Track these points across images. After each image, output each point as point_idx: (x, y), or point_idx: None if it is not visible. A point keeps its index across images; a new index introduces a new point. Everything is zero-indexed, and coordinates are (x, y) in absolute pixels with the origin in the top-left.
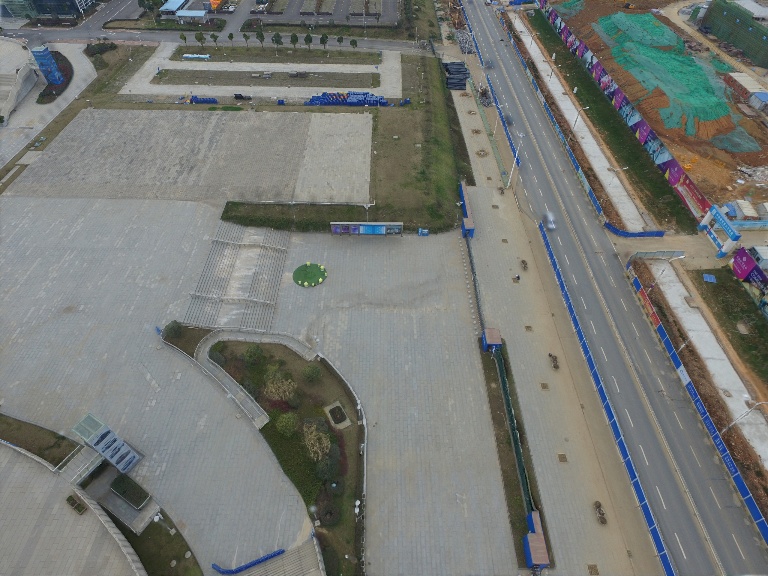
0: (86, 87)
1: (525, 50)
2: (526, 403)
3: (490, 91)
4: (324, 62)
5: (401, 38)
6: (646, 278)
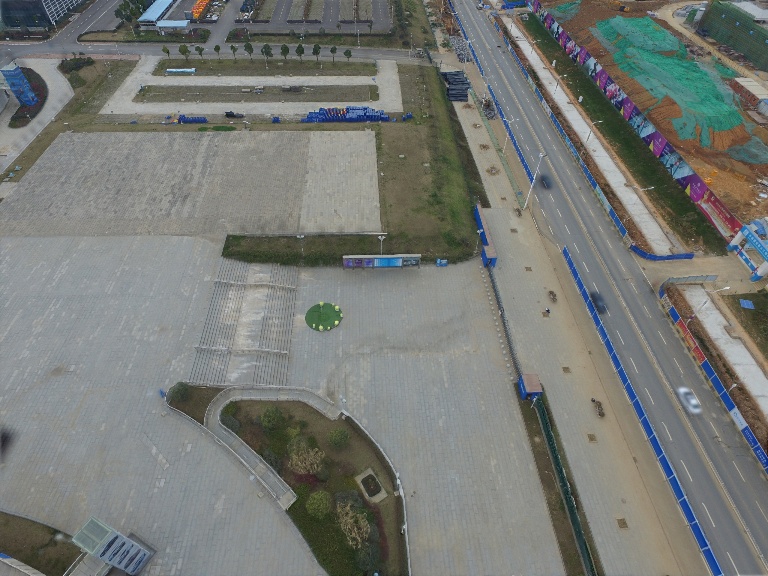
0: (63, 107)
1: (523, 57)
2: (575, 459)
3: (493, 102)
4: None
5: (395, 46)
6: (682, 306)
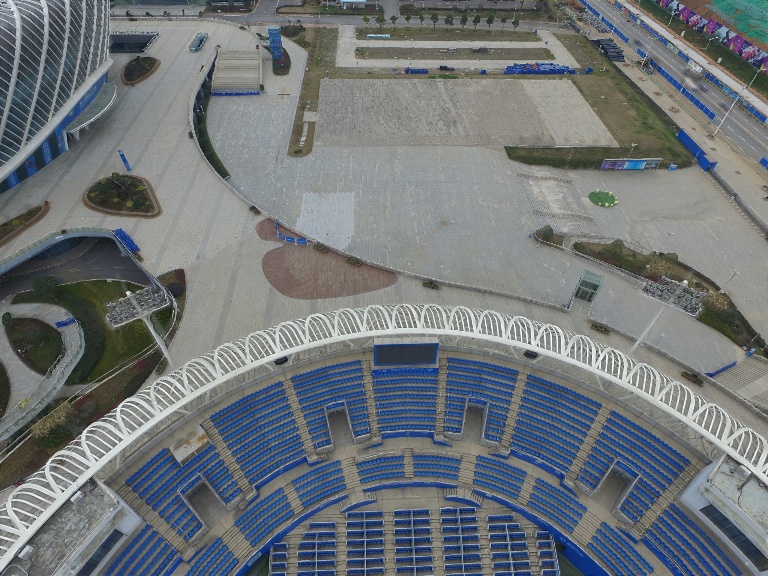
0: (307, 62)
1: (653, 29)
2: None
3: None
4: (492, 40)
5: (542, 20)
6: None
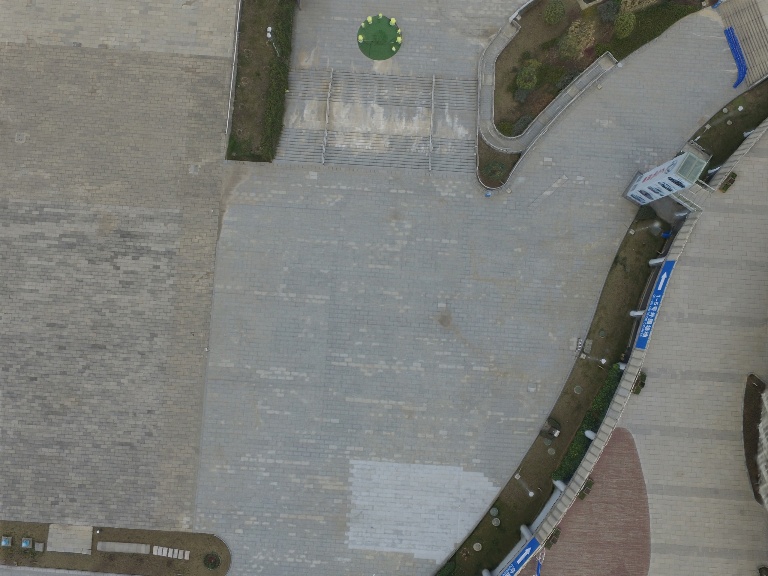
0: None
1: None
2: None
3: None
4: None
5: None
6: None
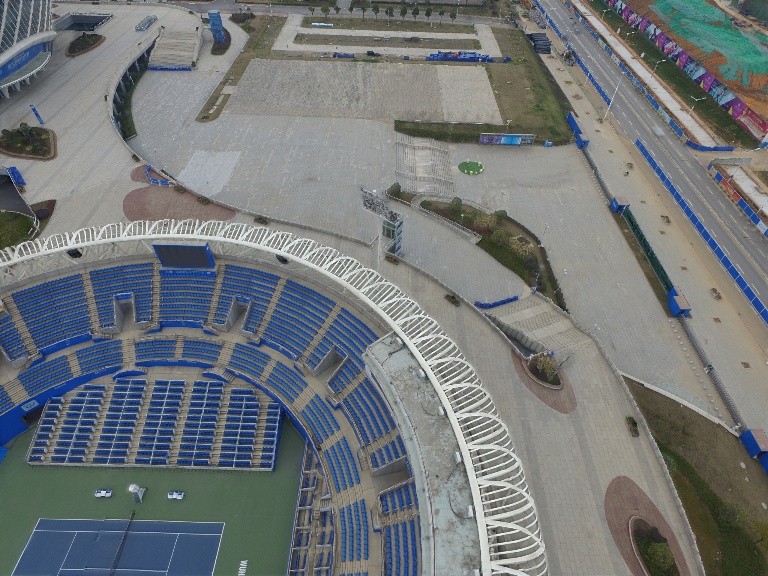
0: (245, 44)
1: (592, 26)
2: (652, 240)
3: None
4: (429, 31)
5: (486, 15)
6: (724, 175)
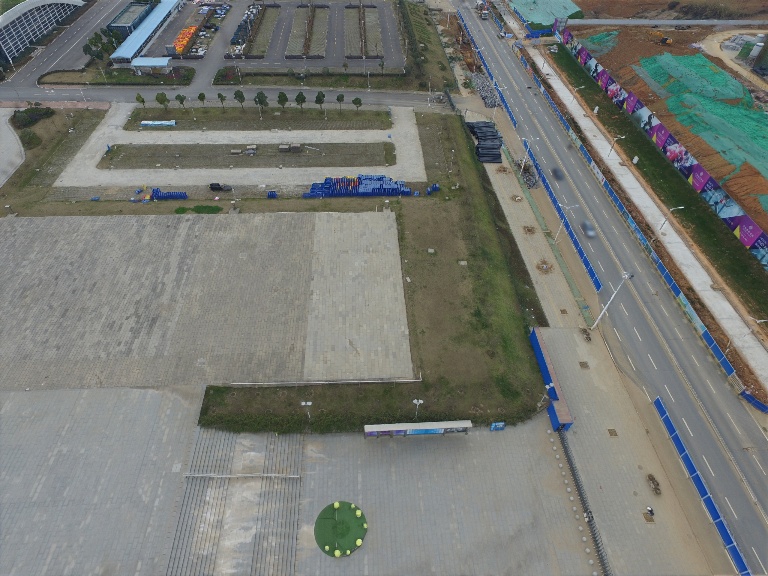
0: (8, 178)
1: (559, 101)
2: None
3: None
4: (321, 127)
5: (411, 88)
6: None
